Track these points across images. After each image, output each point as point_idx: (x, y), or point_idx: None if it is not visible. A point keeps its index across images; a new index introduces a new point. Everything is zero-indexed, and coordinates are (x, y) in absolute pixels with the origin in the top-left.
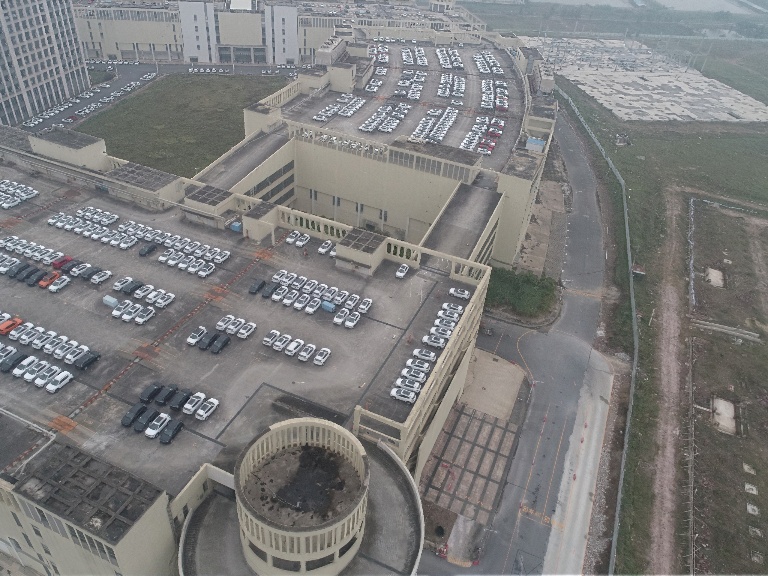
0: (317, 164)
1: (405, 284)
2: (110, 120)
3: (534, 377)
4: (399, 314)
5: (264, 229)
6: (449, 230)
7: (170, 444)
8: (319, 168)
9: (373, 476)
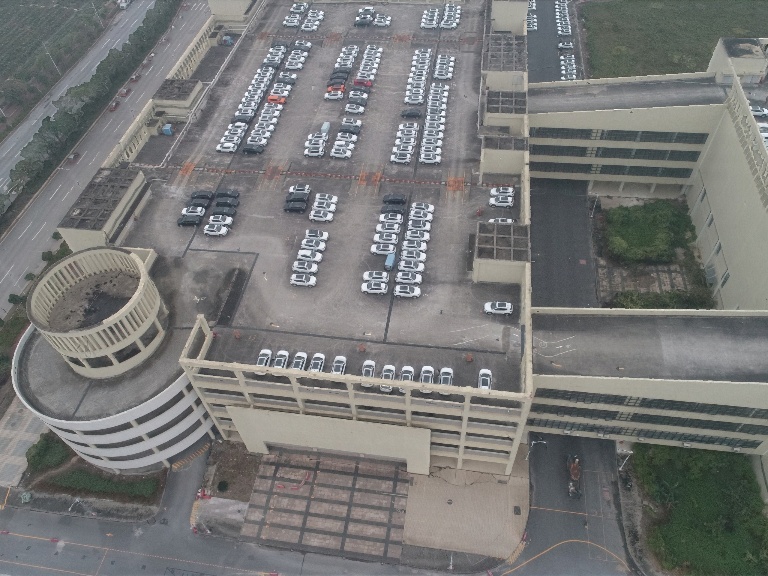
0: (723, 156)
1: (477, 319)
2: (710, 1)
3: (509, 575)
4: (412, 328)
5: (493, 164)
6: (641, 335)
7: (179, 227)
8: (722, 163)
9: (166, 367)
